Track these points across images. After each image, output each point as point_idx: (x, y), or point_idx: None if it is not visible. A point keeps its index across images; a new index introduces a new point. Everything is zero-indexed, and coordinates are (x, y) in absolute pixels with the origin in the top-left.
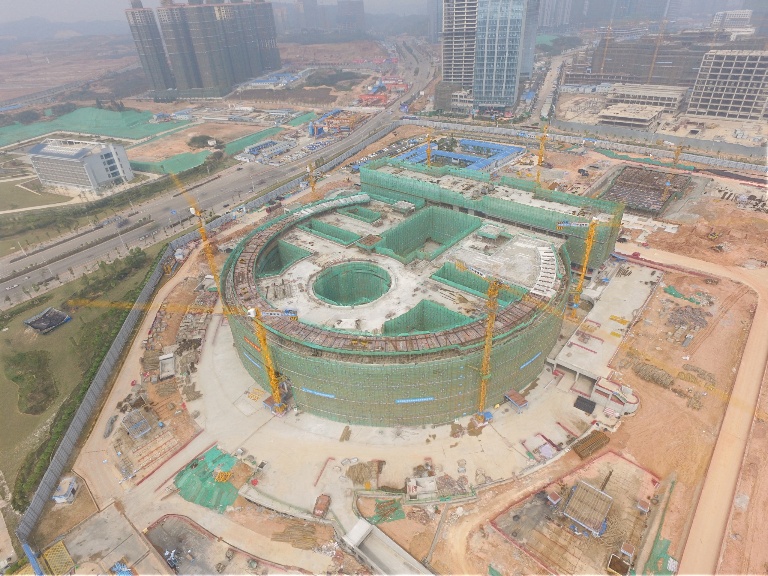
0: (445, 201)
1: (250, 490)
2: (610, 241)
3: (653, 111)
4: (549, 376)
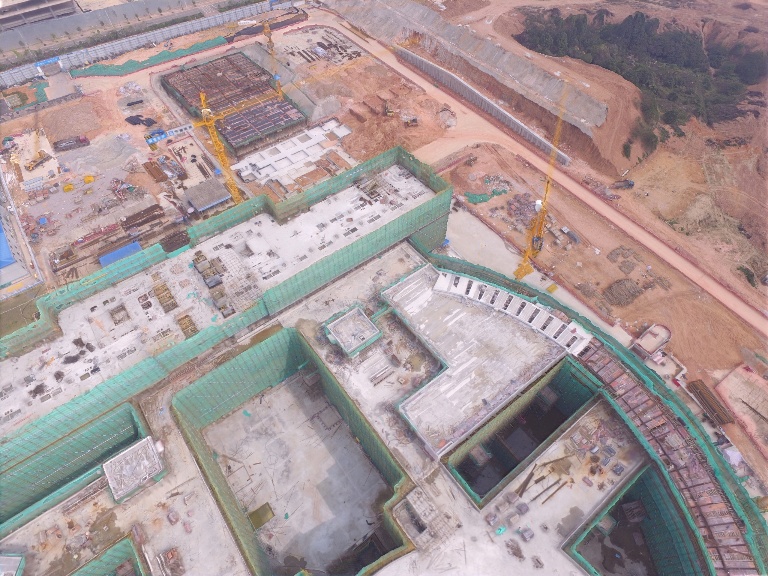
0: (180, 364)
1: None
2: None
3: None
4: None
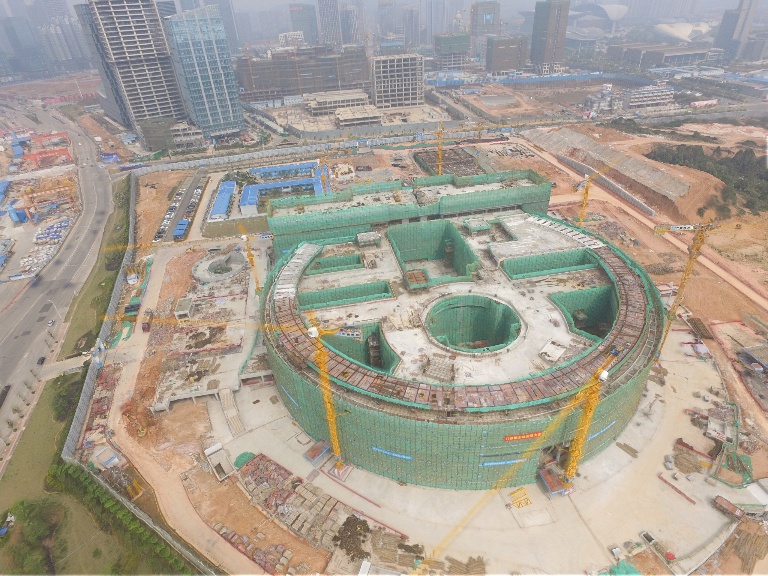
0: (395, 218)
1: (682, 565)
2: None
3: (373, 109)
4: None
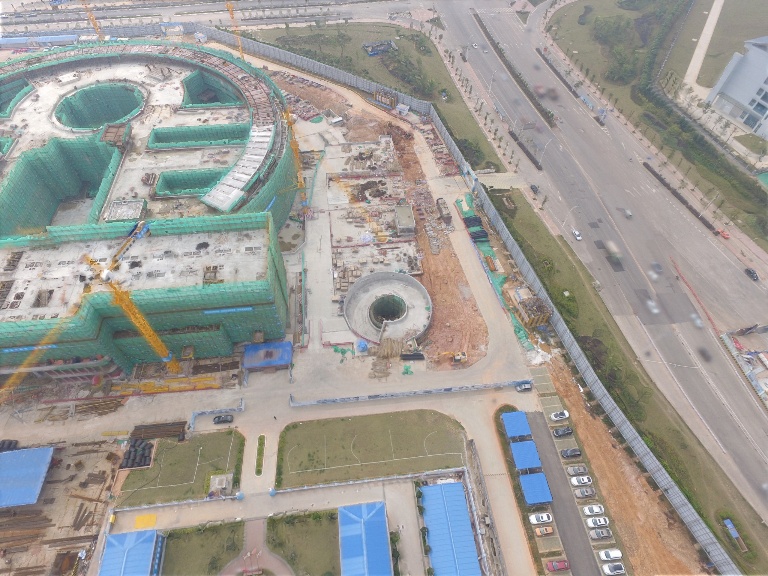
0: None
1: None
2: None
3: None
4: None
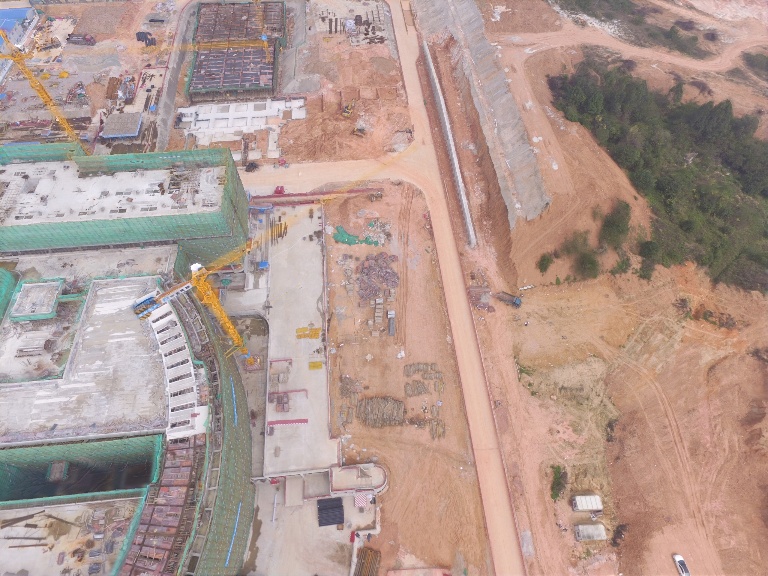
0: None
1: None
2: (239, 216)
3: None
4: (268, 491)
